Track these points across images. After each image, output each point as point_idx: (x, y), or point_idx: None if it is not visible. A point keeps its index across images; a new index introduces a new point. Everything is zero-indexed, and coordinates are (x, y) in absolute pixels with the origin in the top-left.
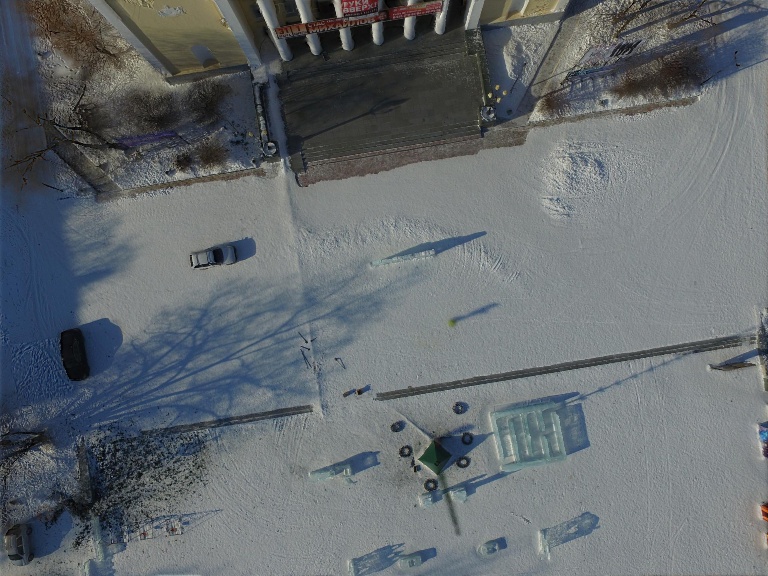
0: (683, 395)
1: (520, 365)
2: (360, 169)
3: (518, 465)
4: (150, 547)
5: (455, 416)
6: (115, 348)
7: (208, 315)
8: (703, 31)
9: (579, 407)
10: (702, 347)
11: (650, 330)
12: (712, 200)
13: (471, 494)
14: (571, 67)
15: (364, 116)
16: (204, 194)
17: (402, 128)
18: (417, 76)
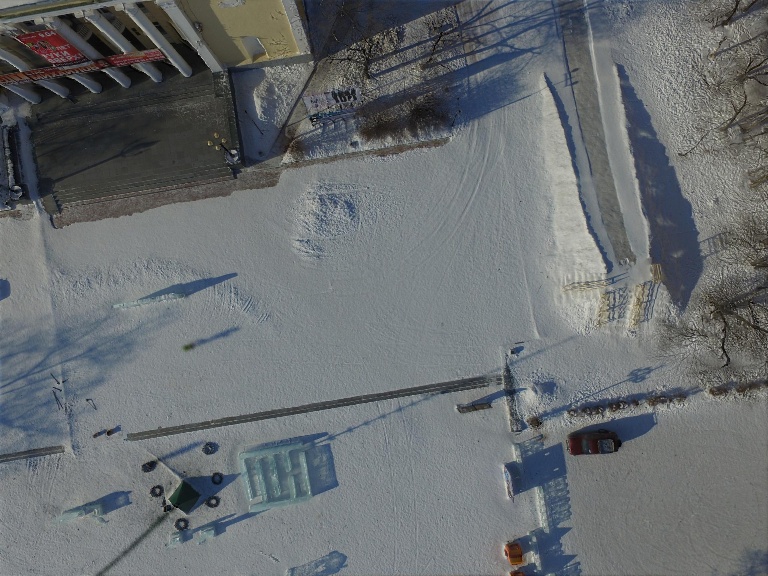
0: (431, 435)
1: (268, 406)
2: (114, 211)
3: (262, 506)
4: None
5: (205, 456)
6: None
7: None
8: (456, 72)
9: (328, 447)
10: (449, 388)
11: (397, 371)
12: (461, 241)
13: (221, 533)
14: (324, 108)
15: (114, 158)
16: None
17: (152, 170)
18: (167, 118)
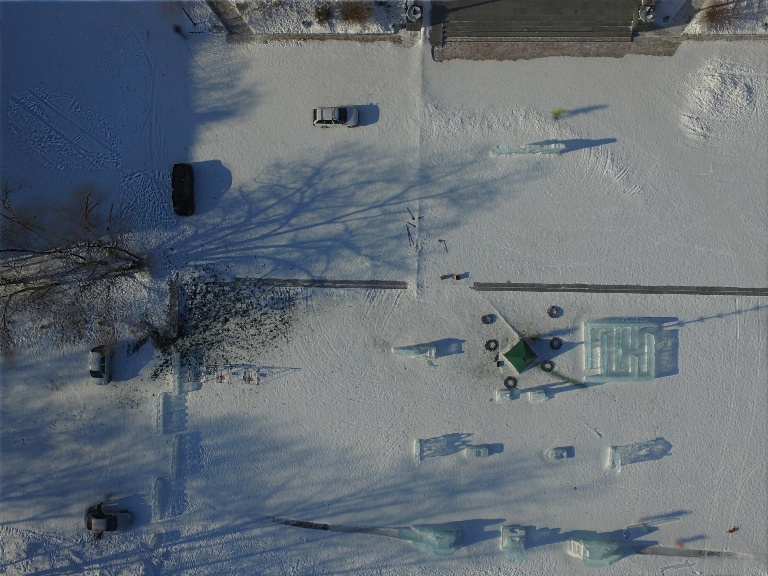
0: None
1: (624, 280)
2: (499, 53)
3: (604, 377)
4: (225, 391)
5: (548, 319)
6: (223, 191)
7: (320, 174)
8: None
9: (675, 333)
10: None
11: (765, 268)
12: None
13: (549, 399)
14: None
15: None
16: (336, 52)
17: (552, 16)
18: None
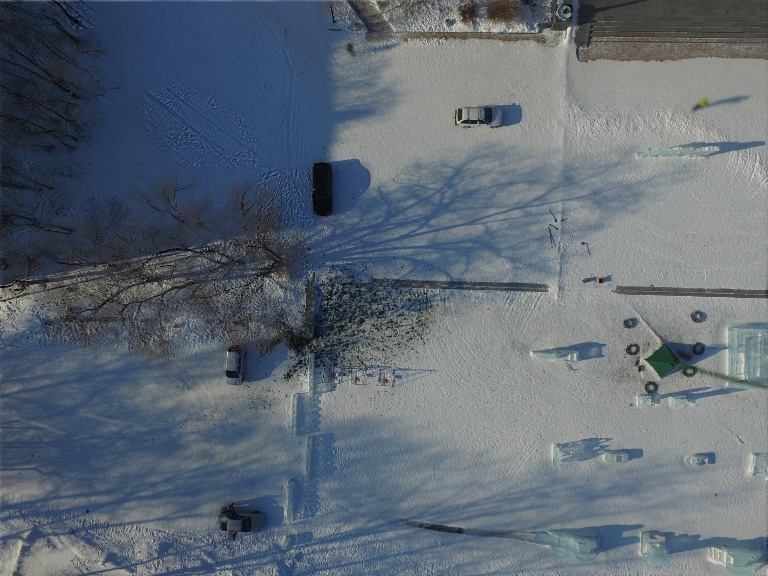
0: None
1: None
2: (645, 54)
3: (750, 383)
4: (359, 393)
5: (691, 324)
6: (361, 191)
7: (460, 175)
8: None
9: None
10: None
11: None
12: None
13: None
14: None
15: None
16: (478, 51)
17: (703, 16)
18: None
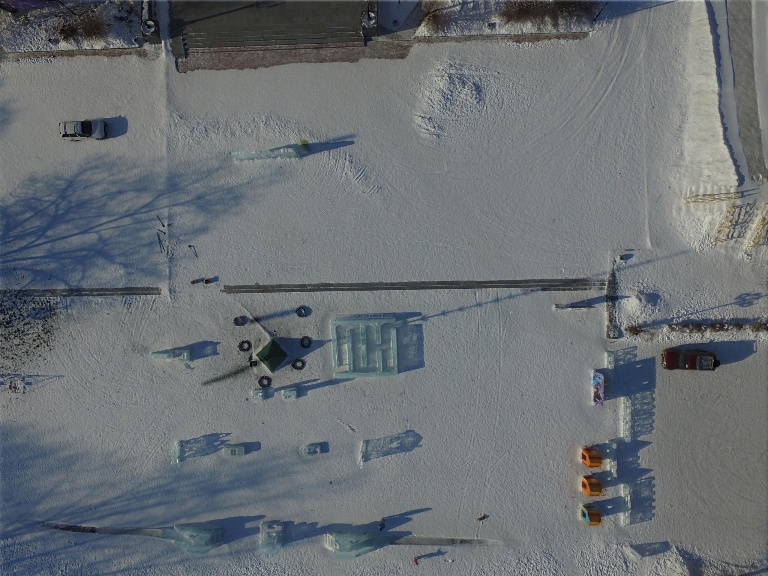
0: (524, 331)
1: (367, 278)
2: (240, 62)
3: (348, 373)
4: None
5: (297, 319)
6: None
7: (73, 187)
8: None
9: (420, 327)
10: (550, 286)
11: (501, 261)
12: (585, 140)
13: (302, 396)
14: None
15: (248, 8)
16: (84, 67)
17: (284, 25)
18: None
